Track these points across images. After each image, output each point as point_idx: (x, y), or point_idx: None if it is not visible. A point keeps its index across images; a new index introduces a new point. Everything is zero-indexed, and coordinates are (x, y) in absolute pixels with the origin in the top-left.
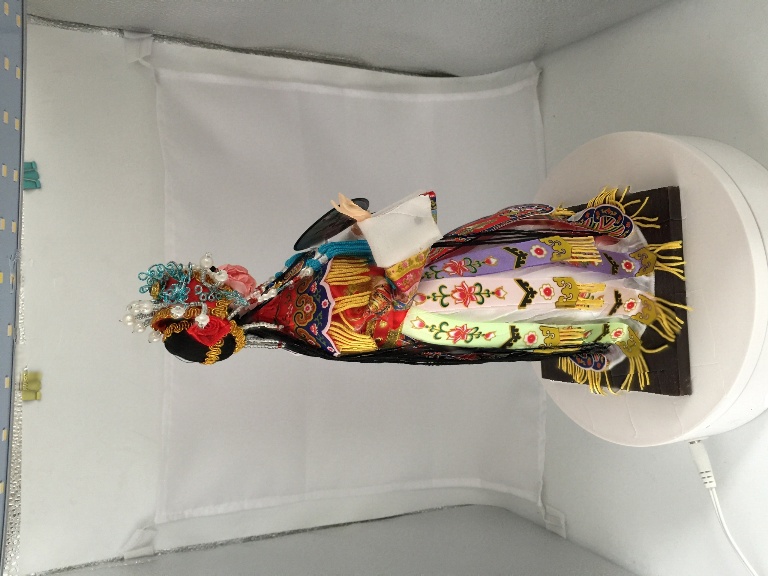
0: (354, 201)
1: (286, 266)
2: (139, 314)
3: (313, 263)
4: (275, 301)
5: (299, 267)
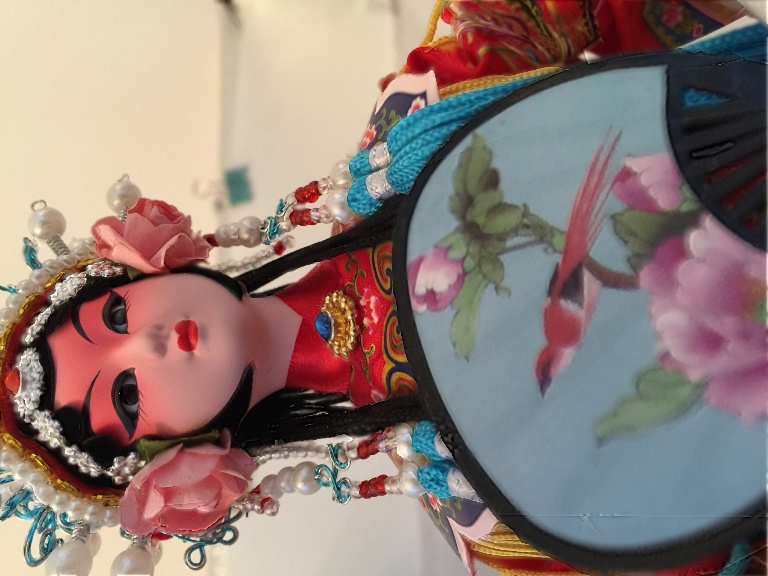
0: (694, 541)
1: (385, 181)
2: None
3: None
4: (338, 372)
5: None
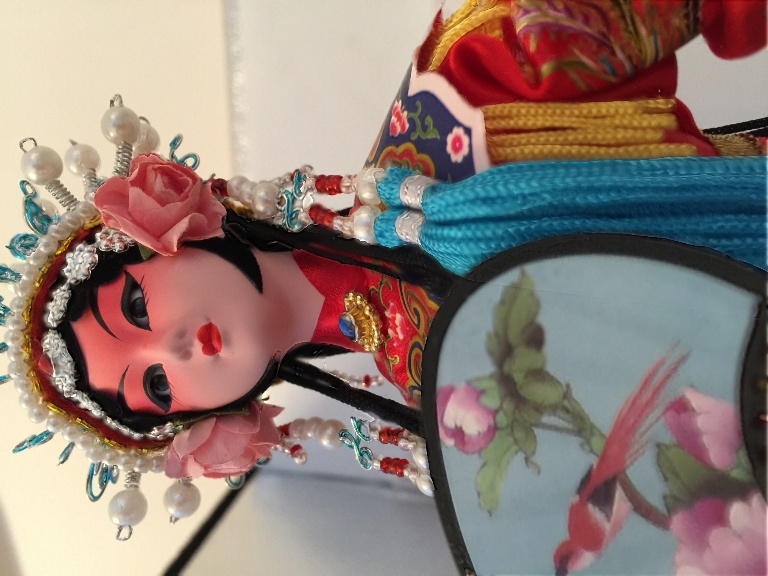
0: None
1: None
2: (22, 237)
3: None
4: None
5: None
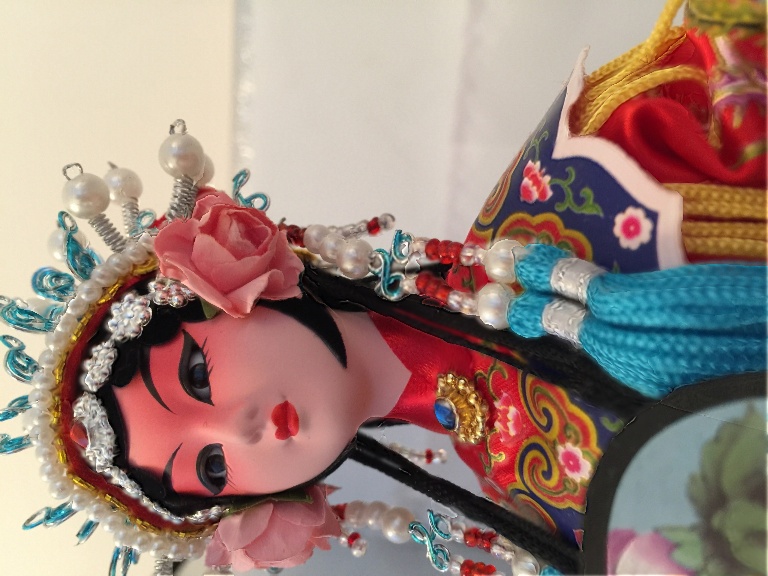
0: None
1: (576, 339)
2: (48, 272)
3: None
4: None
5: (557, 498)
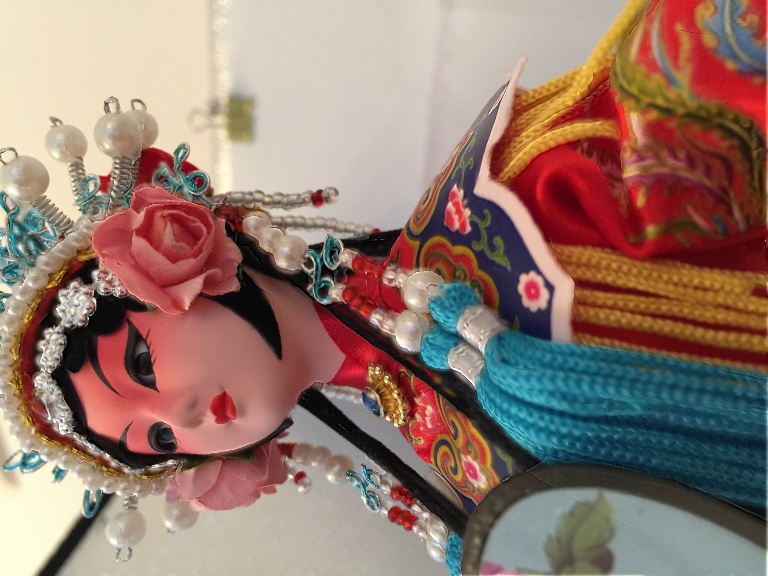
0: None
1: None
2: (0, 234)
3: (453, 574)
4: None
5: None
